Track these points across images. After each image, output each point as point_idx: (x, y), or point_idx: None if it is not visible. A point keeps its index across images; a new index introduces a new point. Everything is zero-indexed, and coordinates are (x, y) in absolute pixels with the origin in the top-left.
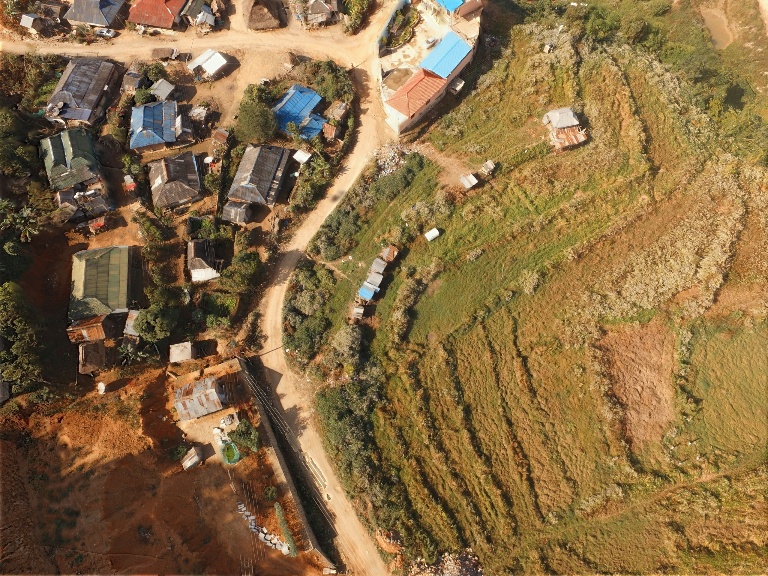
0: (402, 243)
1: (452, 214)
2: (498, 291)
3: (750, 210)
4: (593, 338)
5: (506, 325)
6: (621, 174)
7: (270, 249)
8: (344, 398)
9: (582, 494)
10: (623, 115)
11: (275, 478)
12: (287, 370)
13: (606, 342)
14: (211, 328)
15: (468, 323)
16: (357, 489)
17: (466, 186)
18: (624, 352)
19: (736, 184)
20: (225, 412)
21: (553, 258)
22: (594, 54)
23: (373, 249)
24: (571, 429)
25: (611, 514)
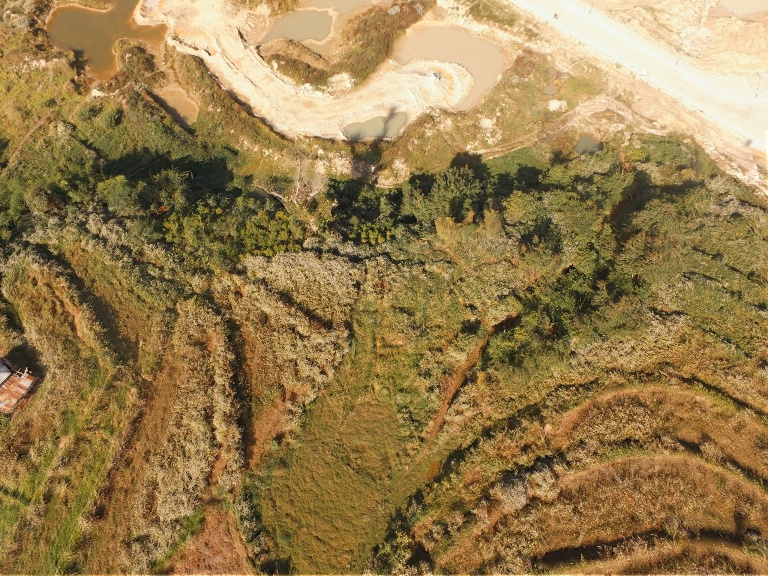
0: None
1: None
2: None
3: (239, 324)
4: None
5: None
6: (96, 384)
7: None
8: None
9: None
10: (71, 312)
11: None
12: None
13: None
14: None
15: None
16: None
17: None
18: (198, 573)
19: (210, 311)
20: None
21: (70, 539)
22: (10, 261)
23: None
24: None
25: None
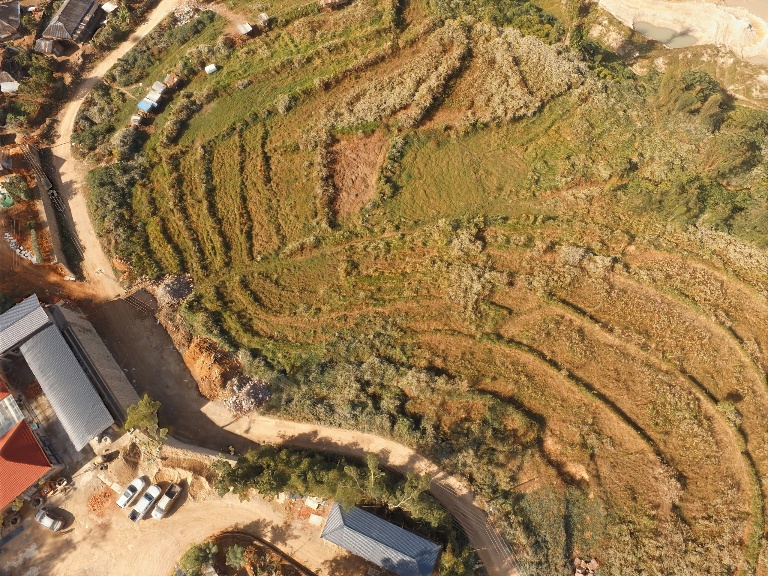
0: (185, 74)
1: (231, 55)
2: (255, 109)
3: (474, 55)
4: (322, 141)
5: (258, 134)
6: None
7: (73, 75)
8: (108, 173)
9: (288, 244)
10: None
11: (39, 219)
12: (70, 157)
13: (337, 148)
14: (10, 123)
15: (226, 131)
16: (104, 230)
17: (242, 32)
18: (349, 154)
19: (464, 34)
20: (8, 176)
21: (304, 86)
22: None
23: (160, 78)
24: (291, 203)
25: (305, 256)
